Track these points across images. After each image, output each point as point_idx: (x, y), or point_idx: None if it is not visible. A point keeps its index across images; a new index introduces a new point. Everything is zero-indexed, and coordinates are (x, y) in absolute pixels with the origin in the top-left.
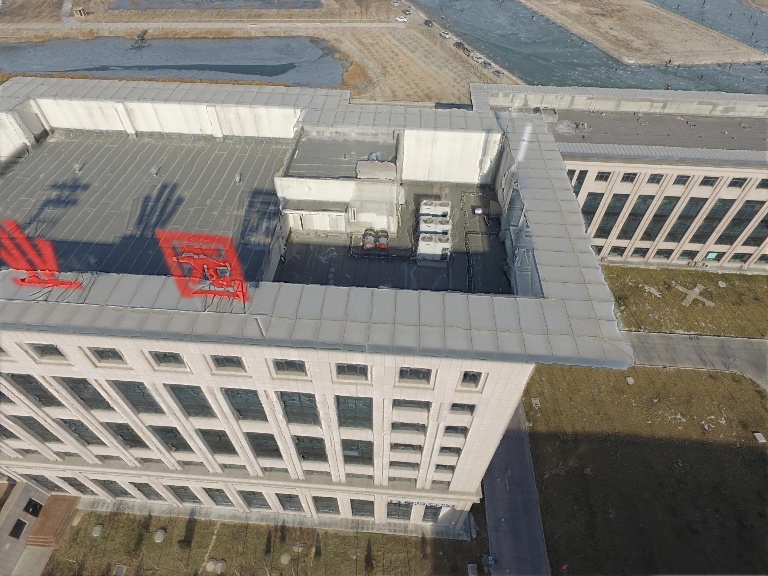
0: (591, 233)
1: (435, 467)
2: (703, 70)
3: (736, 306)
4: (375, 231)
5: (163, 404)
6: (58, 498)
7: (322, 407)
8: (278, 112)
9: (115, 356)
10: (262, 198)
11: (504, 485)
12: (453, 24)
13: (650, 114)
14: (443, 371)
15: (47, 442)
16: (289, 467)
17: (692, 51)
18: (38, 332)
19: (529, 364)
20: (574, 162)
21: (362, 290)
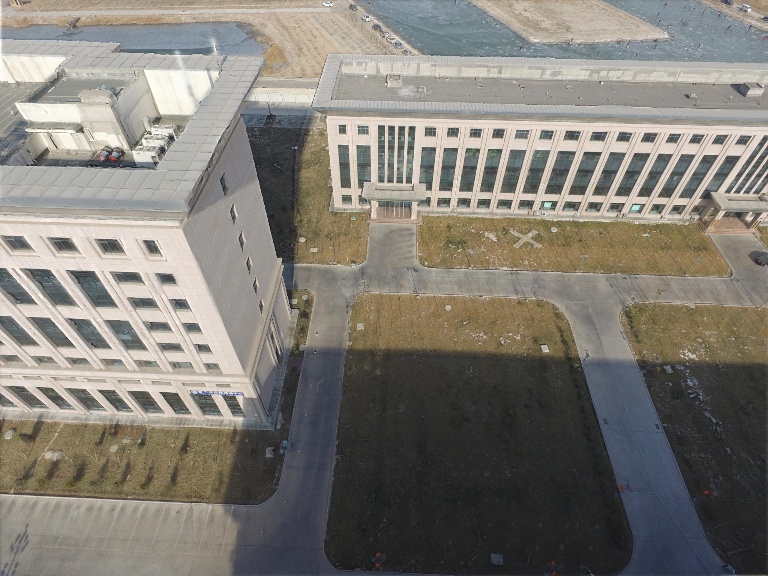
0: (436, 186)
1: (194, 346)
2: (602, 47)
3: (561, 247)
4: (112, 148)
5: None
6: None
7: (65, 284)
8: (54, 60)
9: None
10: None
11: (315, 389)
12: (378, 8)
13: (489, 79)
14: (124, 240)
15: None
16: (85, 355)
17: (595, 30)
18: None
19: (178, 229)
20: (401, 119)
21: (25, 167)
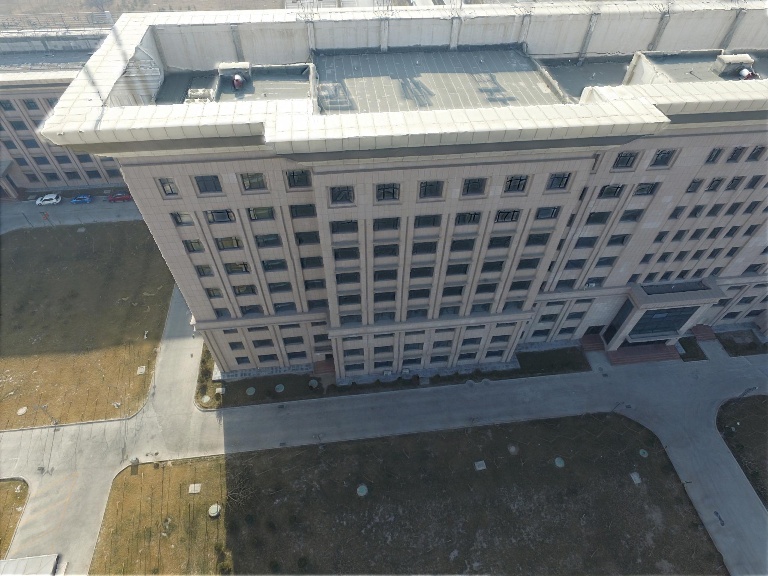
0: None
1: None
2: None
3: None
4: None
5: None
6: None
7: None
8: None
9: None
10: (338, 106)
11: None
12: None
13: None
14: None
15: None
16: None
17: None
18: None
19: None
20: None
21: None
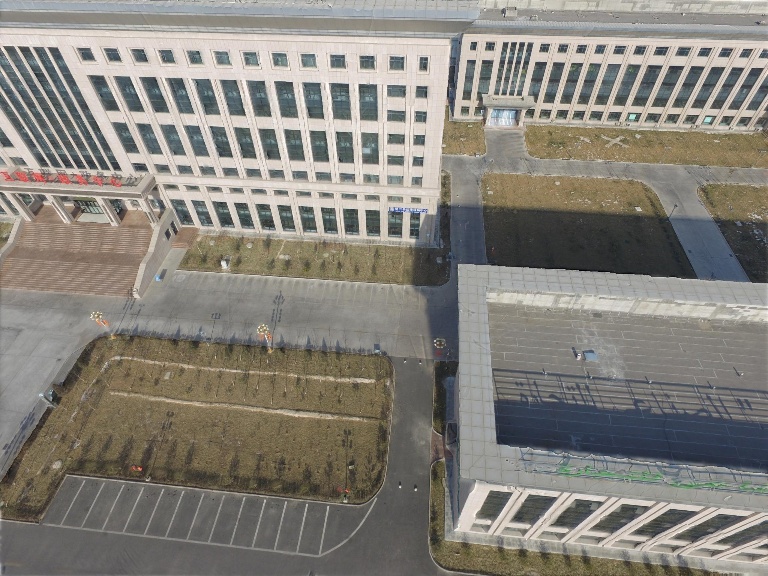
0: (541, 98)
1: (412, 158)
2: None
3: (644, 147)
4: None
5: (271, 102)
6: (186, 228)
7: (352, 97)
8: None
9: (253, 63)
10: None
11: (464, 227)
12: None
13: (588, 12)
14: (409, 56)
15: (197, 156)
16: (331, 168)
17: None
18: (223, 40)
19: (448, 46)
20: (523, 36)
21: None
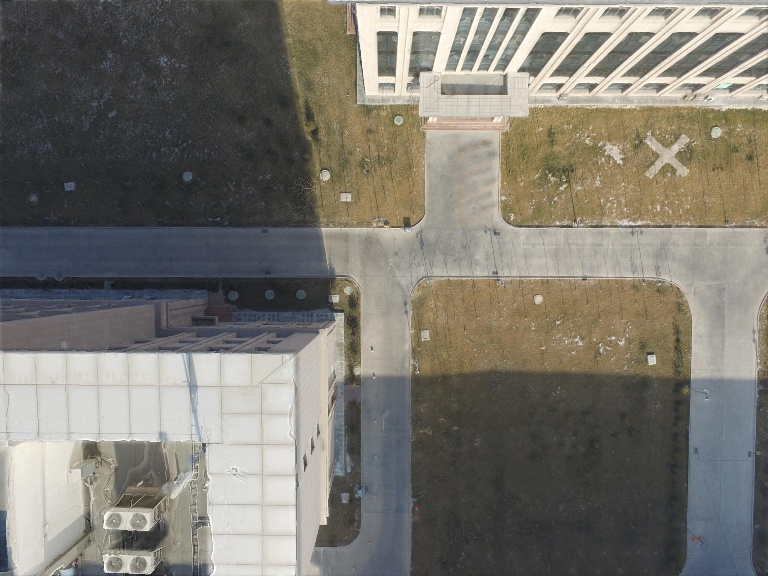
0: (546, 74)
1: None
2: None
3: (716, 172)
4: None
5: None
6: None
7: None
8: None
9: None
10: None
11: (380, 426)
12: None
13: None
14: None
15: None
16: None
17: None
18: None
19: None
20: None
21: None
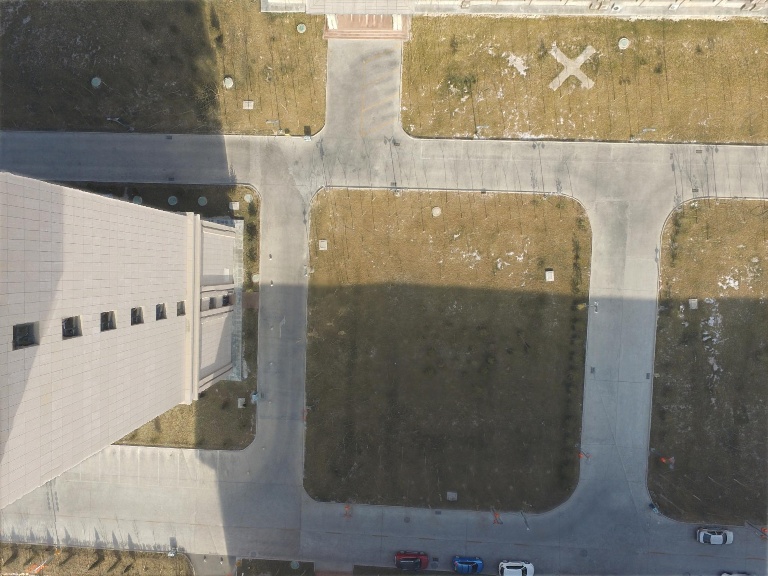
0: None
1: None
2: None
3: (623, 85)
4: None
5: None
6: None
7: None
8: None
9: None
10: None
11: (277, 333)
12: None
13: None
14: None
15: None
16: None
17: None
18: None
19: None
20: None
21: None
